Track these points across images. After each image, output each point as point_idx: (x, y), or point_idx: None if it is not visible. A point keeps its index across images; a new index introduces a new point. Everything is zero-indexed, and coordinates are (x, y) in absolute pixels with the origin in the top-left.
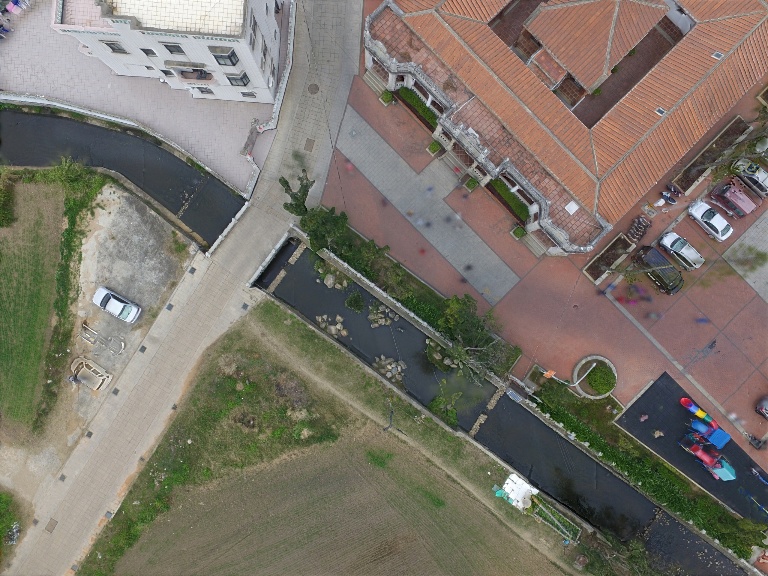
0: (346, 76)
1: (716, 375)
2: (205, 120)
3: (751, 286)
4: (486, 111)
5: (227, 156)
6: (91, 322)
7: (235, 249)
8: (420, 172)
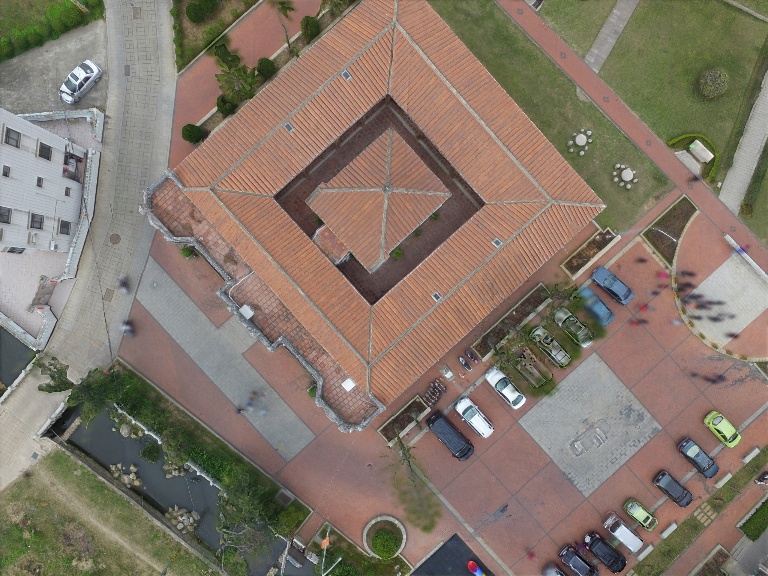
0: (149, 227)
1: (506, 539)
2: (3, 267)
3: (546, 452)
4: (266, 285)
5: (25, 303)
6: None
7: (27, 398)
8: (220, 326)
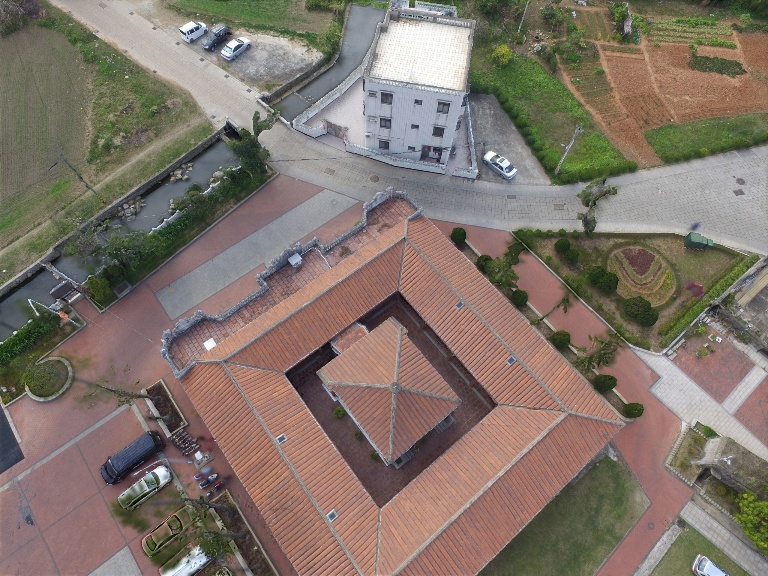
0: None
1: None
2: (359, 110)
3: None
4: None
5: (330, 120)
6: (230, 37)
7: None
8: None
